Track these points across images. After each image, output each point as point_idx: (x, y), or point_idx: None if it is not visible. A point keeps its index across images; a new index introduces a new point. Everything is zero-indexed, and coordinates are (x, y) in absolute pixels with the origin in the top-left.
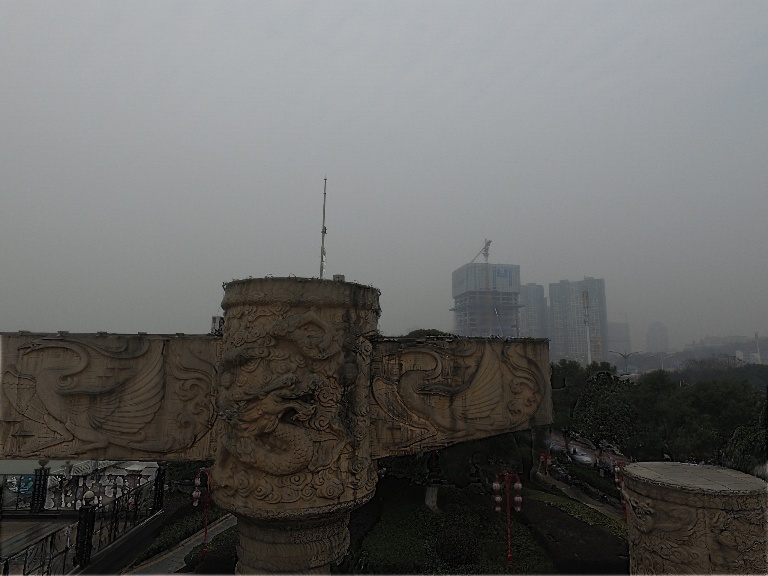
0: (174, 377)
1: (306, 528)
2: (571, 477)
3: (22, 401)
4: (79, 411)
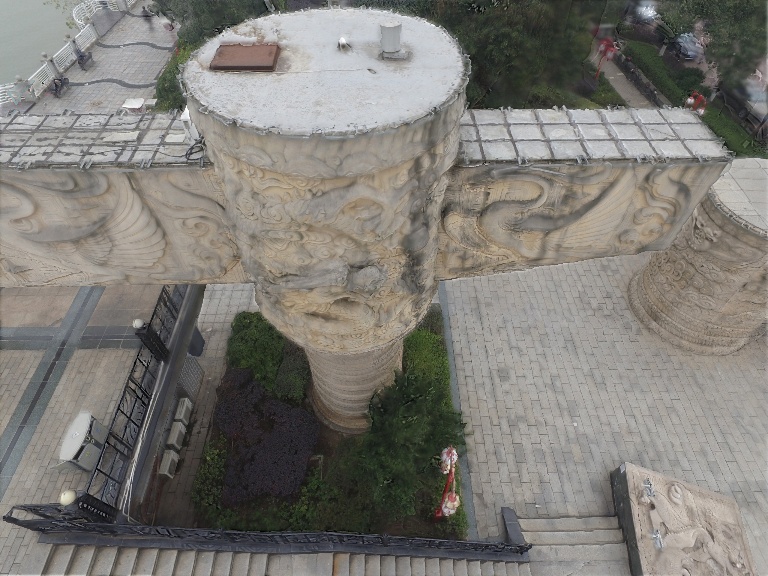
0: (166, 214)
1: None
2: (625, 58)
3: None
4: (67, 253)
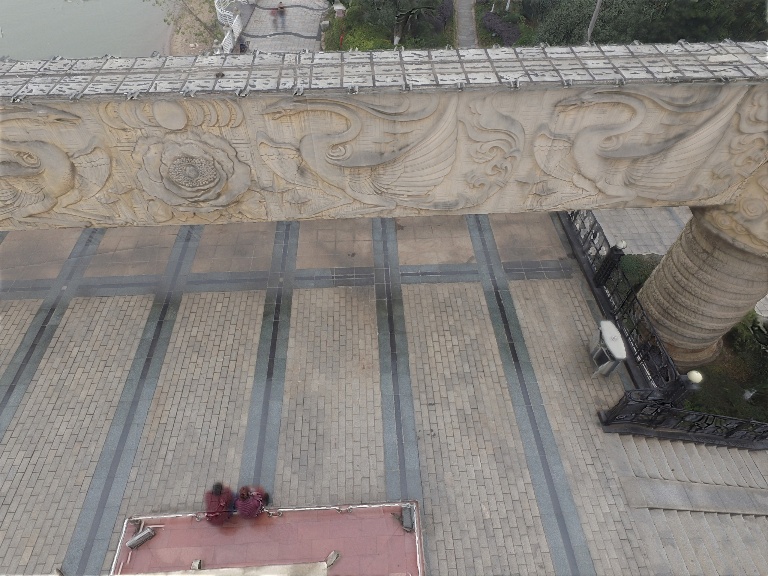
0: (737, 130)
1: None
2: None
3: (551, 162)
4: (618, 171)
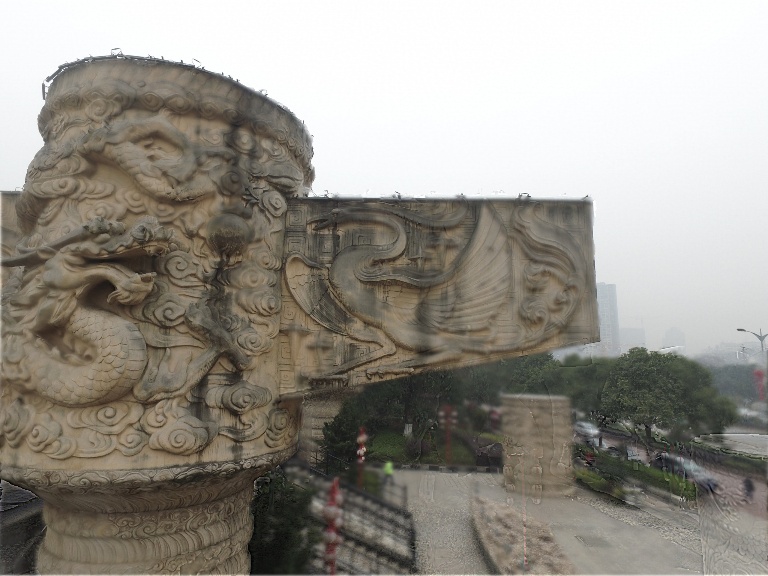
0: None
1: (145, 510)
2: (599, 470)
3: None
4: None
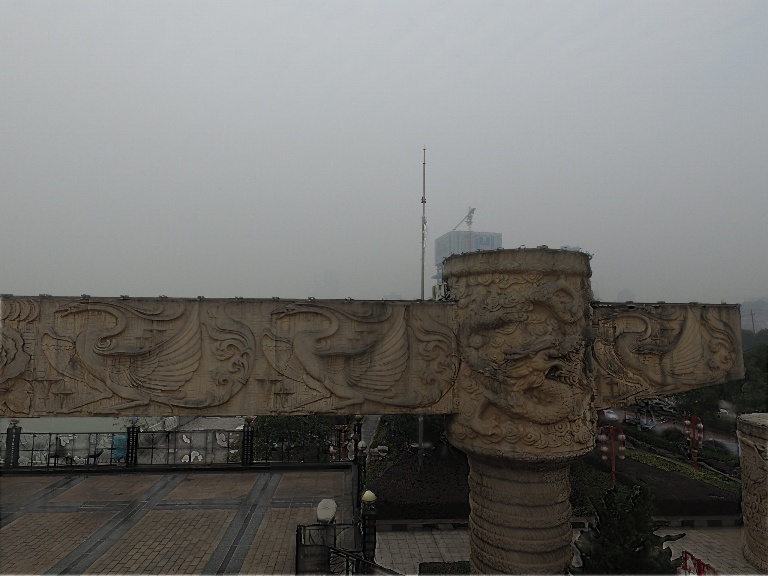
0: (417, 339)
1: (553, 469)
2: None
3: (280, 362)
4: (336, 370)
